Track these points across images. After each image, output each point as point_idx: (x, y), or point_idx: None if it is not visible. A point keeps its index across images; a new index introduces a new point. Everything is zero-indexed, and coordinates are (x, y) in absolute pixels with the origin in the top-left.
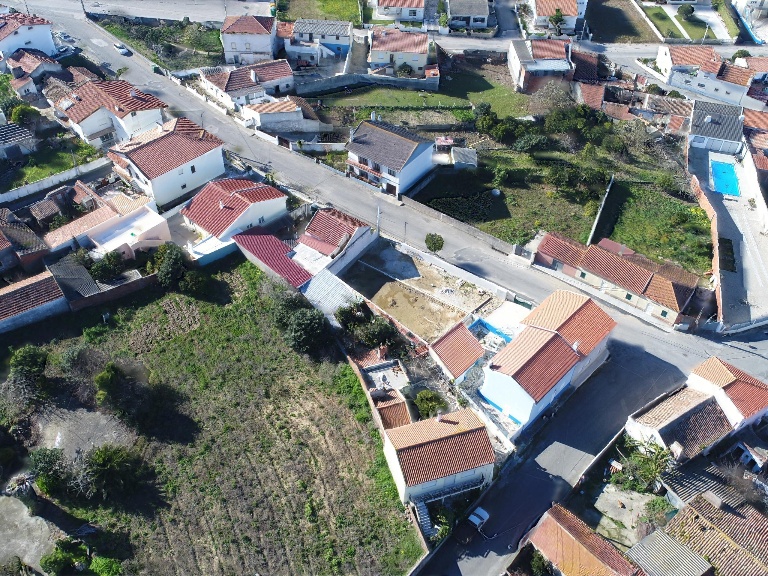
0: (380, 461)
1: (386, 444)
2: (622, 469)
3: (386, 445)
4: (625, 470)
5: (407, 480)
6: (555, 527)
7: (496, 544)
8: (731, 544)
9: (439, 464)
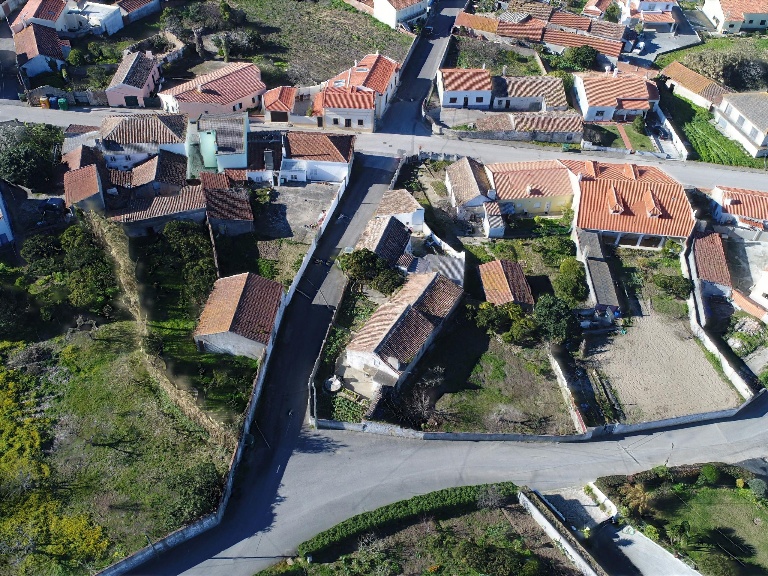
0: (374, 20)
1: (375, 9)
2: (479, 6)
3: (375, 10)
4: (480, 7)
5: (396, 8)
6: (464, 15)
7: (441, 35)
8: (534, 5)
9: (406, 1)
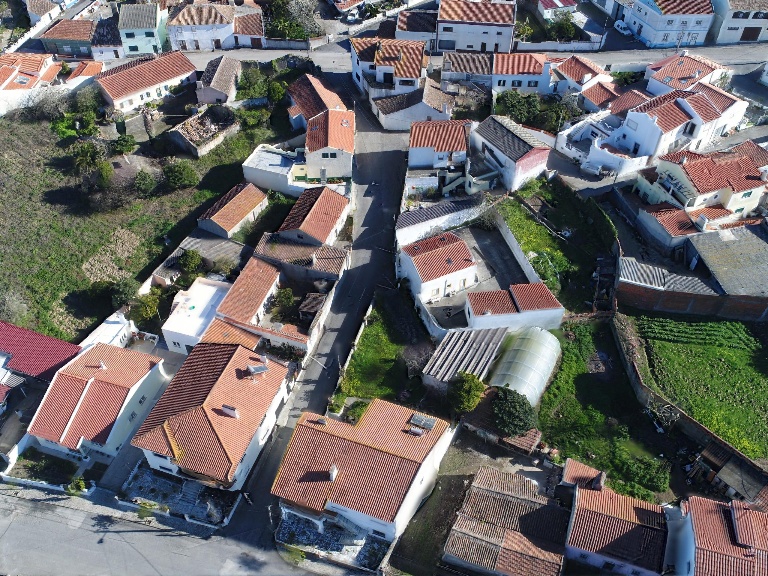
0: None
1: None
2: None
3: None
4: None
5: None
6: None
7: None
8: None
9: None
